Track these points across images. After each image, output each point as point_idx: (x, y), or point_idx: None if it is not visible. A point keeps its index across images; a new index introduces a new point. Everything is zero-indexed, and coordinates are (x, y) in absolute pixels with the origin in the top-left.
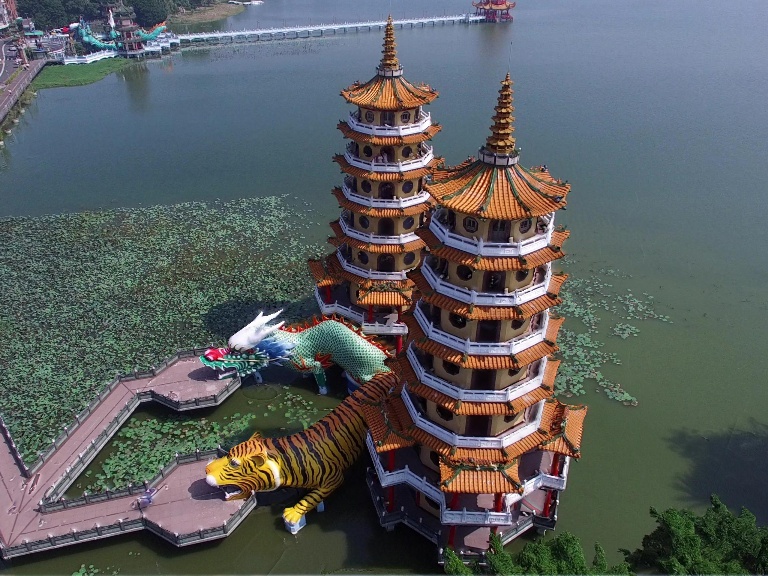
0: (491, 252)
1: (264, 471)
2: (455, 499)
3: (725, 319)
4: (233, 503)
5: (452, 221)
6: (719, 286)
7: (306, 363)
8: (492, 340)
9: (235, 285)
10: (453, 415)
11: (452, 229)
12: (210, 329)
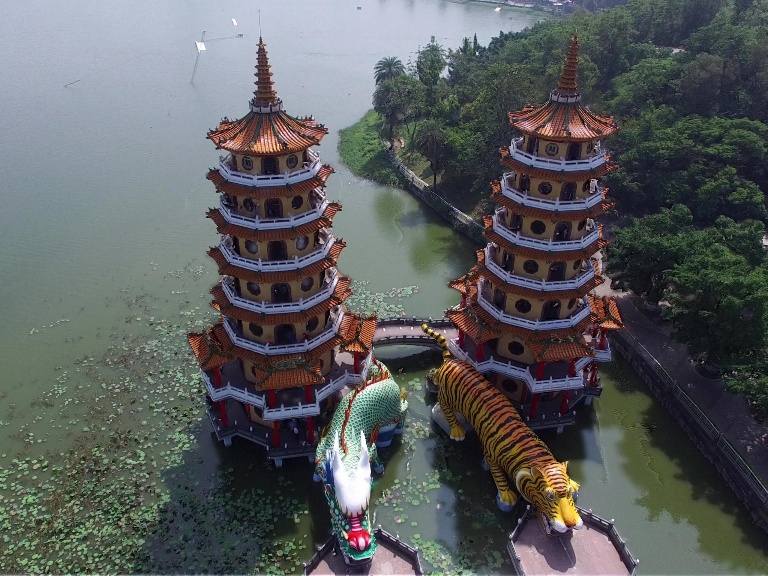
0: None
1: None
2: None
3: None
4: None
5: (571, 156)
6: None
7: None
8: None
9: None
10: None
11: None
12: None
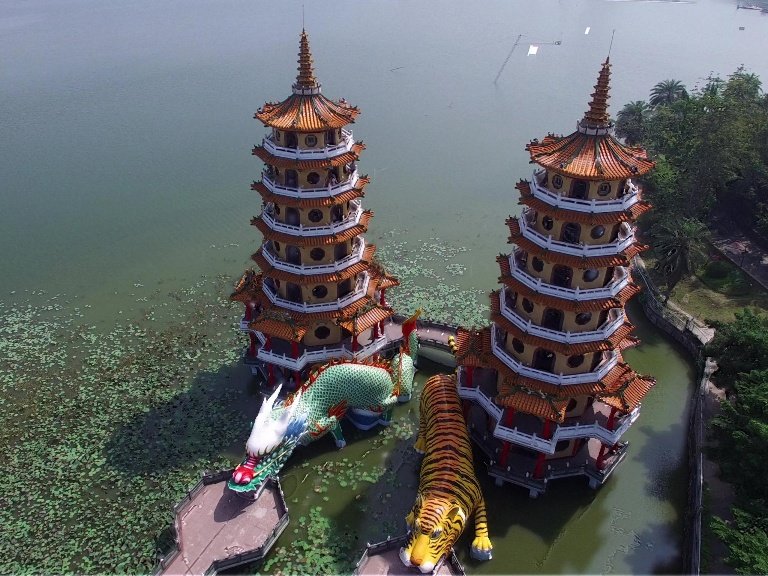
0: (627, 205)
1: (457, 521)
2: (613, 421)
3: (492, 233)
4: (441, 575)
5: (577, 194)
6: (461, 213)
7: (321, 425)
8: (608, 280)
9: (92, 414)
10: (585, 359)
11: (587, 199)
12: (141, 471)
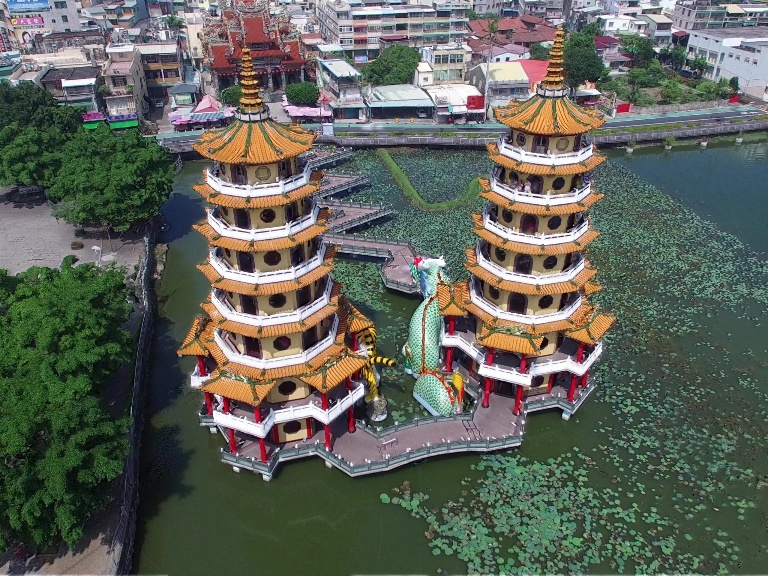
0: None
1: None
2: None
3: None
4: None
5: None
6: None
7: None
8: None
9: None
10: None
11: None
12: None
